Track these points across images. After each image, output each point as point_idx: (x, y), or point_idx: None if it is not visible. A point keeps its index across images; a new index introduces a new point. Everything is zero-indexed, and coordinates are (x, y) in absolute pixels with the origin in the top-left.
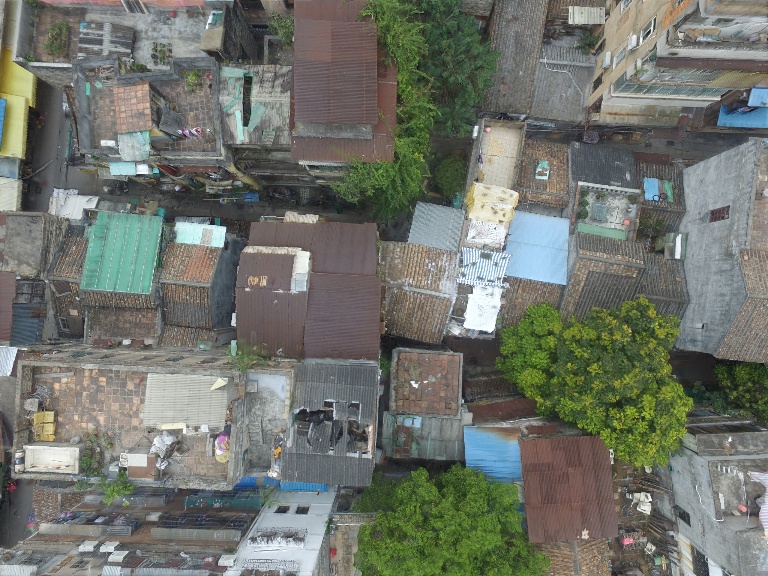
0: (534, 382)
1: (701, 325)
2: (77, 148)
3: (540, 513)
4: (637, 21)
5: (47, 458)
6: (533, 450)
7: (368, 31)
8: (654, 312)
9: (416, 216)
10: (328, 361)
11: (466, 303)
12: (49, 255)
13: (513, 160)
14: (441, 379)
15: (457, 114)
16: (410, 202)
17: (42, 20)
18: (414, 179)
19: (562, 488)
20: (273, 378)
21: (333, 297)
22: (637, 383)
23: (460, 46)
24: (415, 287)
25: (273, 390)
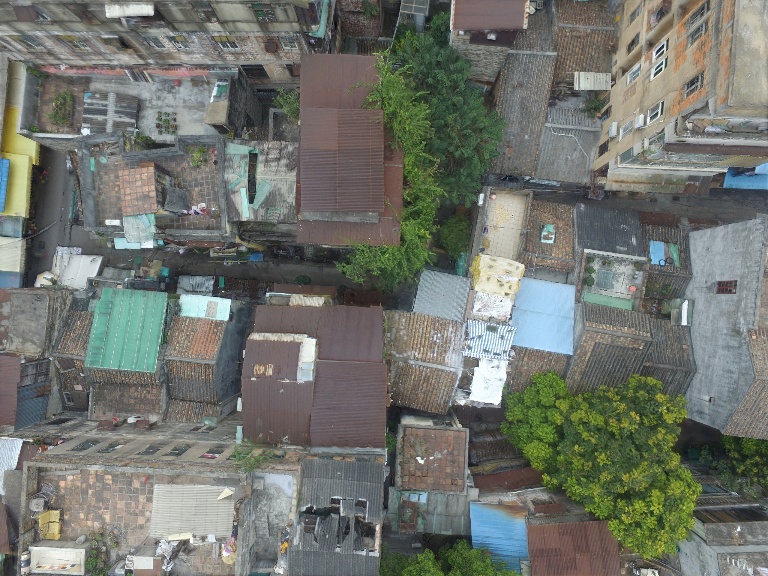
0: (540, 456)
1: (708, 398)
2: (81, 212)
3: None
4: (644, 99)
5: (53, 557)
6: (540, 535)
7: (374, 118)
8: (662, 396)
9: (421, 284)
10: (334, 450)
11: (472, 376)
12: (54, 332)
13: (519, 227)
14: (447, 455)
15: (463, 183)
16: None
17: (46, 89)
18: (420, 258)
19: (569, 574)
20: (280, 474)
21: (339, 385)
22: (646, 477)
23: (466, 119)
24: (421, 361)
25: (280, 486)
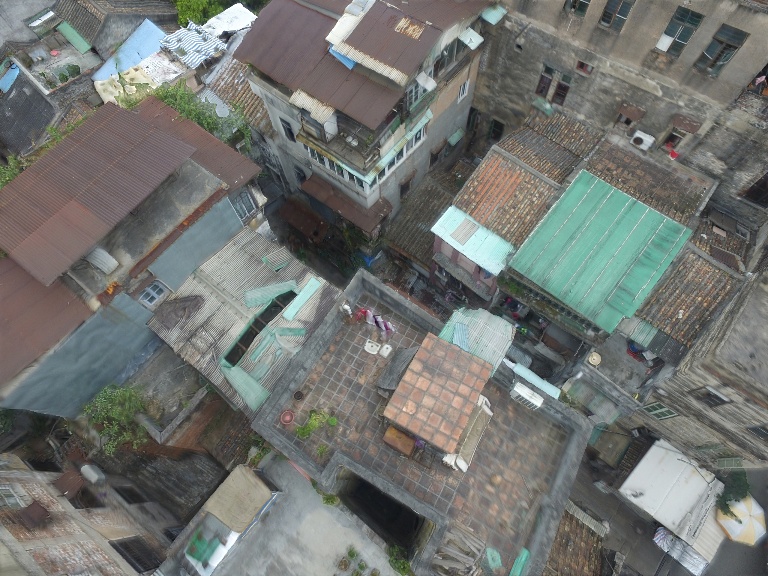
0: None
1: None
2: (616, 571)
3: None
4: None
5: None
6: None
7: None
8: None
9: None
10: None
11: None
12: None
13: None
14: None
15: None
16: None
17: None
18: None
19: None
20: None
21: None
22: None
23: None
24: None
25: None
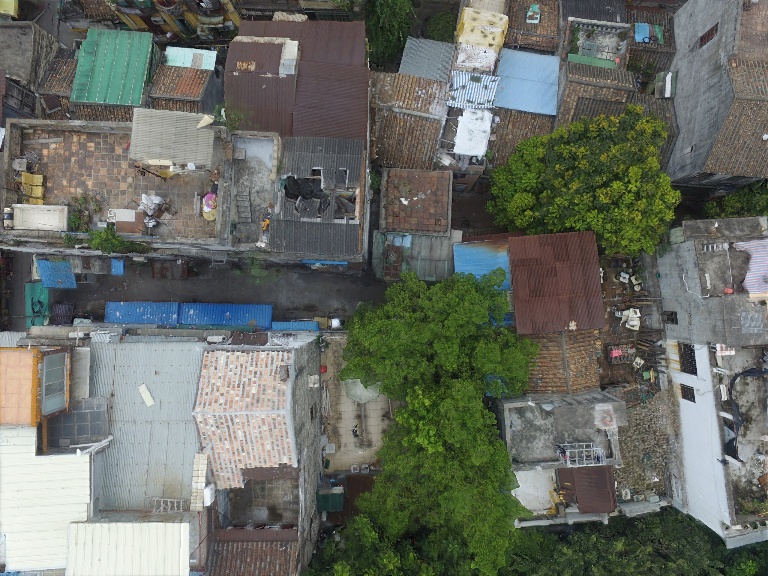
0: (524, 205)
1: (690, 148)
2: None
3: (528, 306)
4: None
5: (36, 222)
6: (521, 246)
7: None
8: (642, 108)
9: (407, 50)
10: None
11: (456, 127)
12: (39, 69)
13: None
14: (431, 196)
15: None
16: (401, 49)
17: None
18: None
19: (550, 282)
20: (261, 147)
21: (321, 85)
22: (623, 156)
23: None
24: (405, 109)
25: (261, 159)
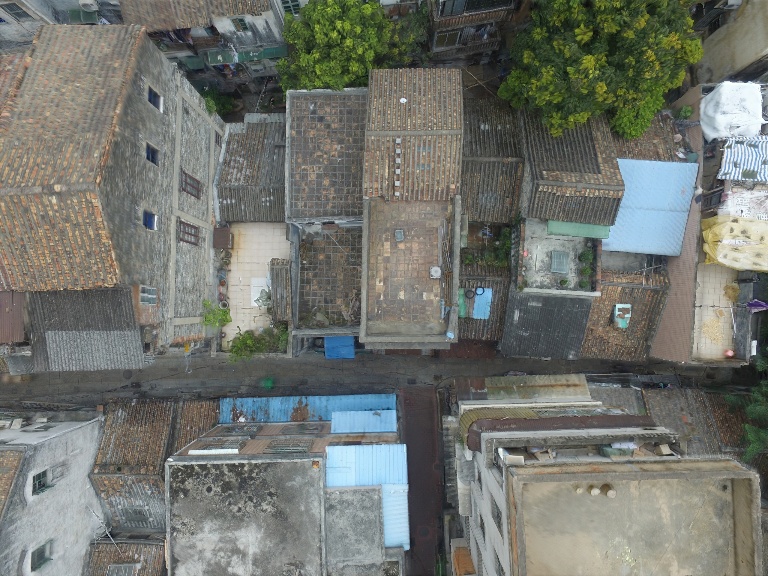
0: None
1: None
2: None
3: None
4: None
5: None
6: None
7: None
8: (600, 89)
9: None
10: None
11: (764, 114)
12: None
13: None
14: None
15: None
16: None
17: None
18: None
19: None
20: None
21: None
22: None
23: None
24: None
25: None
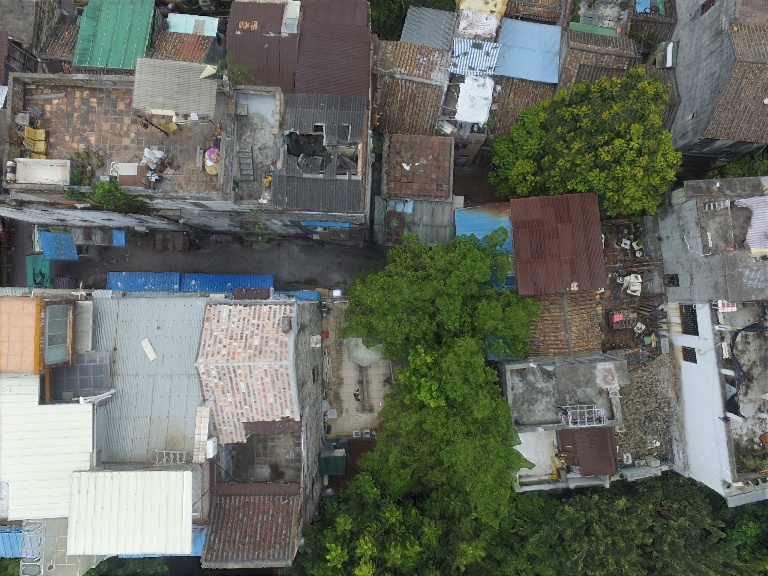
0: (525, 171)
1: (691, 115)
2: None
3: (530, 267)
4: None
5: (38, 177)
6: (523, 208)
7: None
8: None
9: (408, 19)
10: None
11: (458, 94)
12: (41, 34)
13: None
14: (432, 161)
15: None
16: (403, 21)
17: None
18: None
19: (552, 243)
20: (263, 103)
21: (324, 45)
22: (625, 114)
23: None
24: (407, 75)
25: (263, 116)
